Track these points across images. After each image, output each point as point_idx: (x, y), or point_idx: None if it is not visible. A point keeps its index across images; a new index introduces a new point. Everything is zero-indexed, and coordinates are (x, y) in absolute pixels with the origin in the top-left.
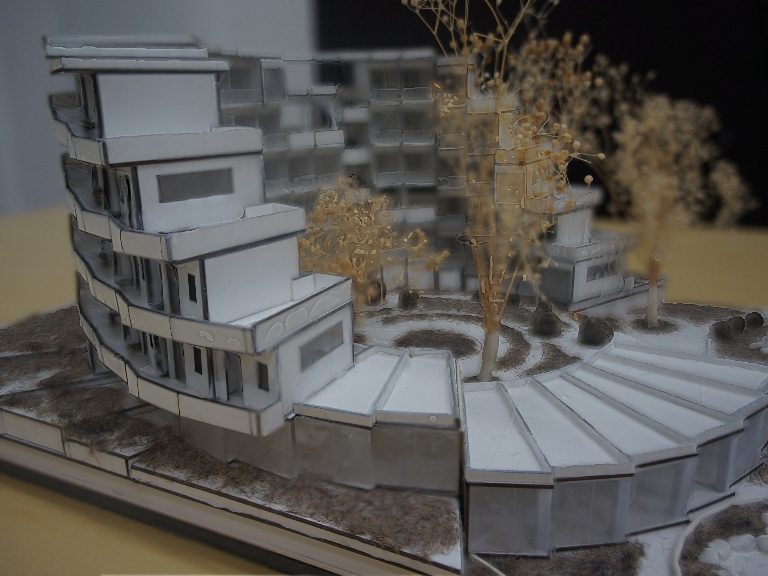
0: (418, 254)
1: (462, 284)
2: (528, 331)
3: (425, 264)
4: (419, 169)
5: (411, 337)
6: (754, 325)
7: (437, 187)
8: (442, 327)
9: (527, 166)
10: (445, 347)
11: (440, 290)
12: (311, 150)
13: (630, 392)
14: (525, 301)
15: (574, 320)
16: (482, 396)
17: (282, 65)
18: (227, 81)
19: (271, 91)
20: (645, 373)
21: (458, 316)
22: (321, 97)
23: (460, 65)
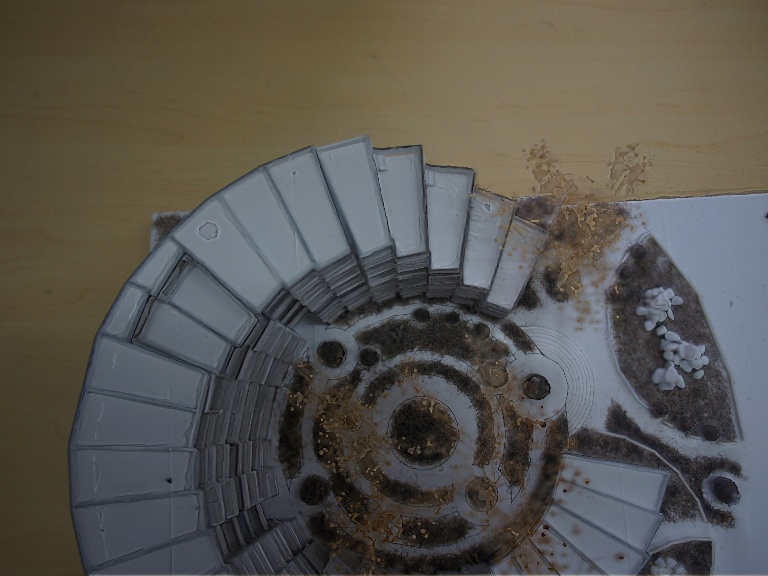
0: None
1: (398, 296)
2: (481, 376)
3: None
4: None
5: (401, 429)
6: (639, 258)
7: (367, 281)
8: (414, 393)
9: None
10: (432, 436)
11: (379, 305)
12: None
13: (586, 530)
14: (460, 308)
15: (509, 338)
16: (506, 569)
17: None
18: None
19: None
20: (590, 496)
21: (420, 371)
22: None
23: None
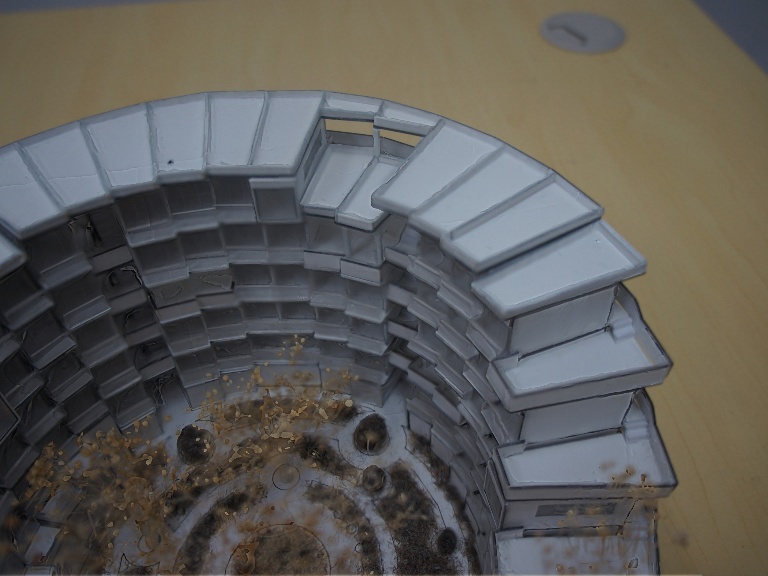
0: (441, 433)
1: None
2: None
3: (446, 447)
4: (455, 365)
5: (280, 542)
6: None
7: None
8: (333, 552)
9: (514, 502)
10: None
11: (447, 482)
12: (336, 272)
13: None
14: None
15: None
16: None
17: (292, 183)
18: (209, 191)
19: (271, 210)
20: None
21: (365, 553)
22: (349, 228)
23: (494, 314)
